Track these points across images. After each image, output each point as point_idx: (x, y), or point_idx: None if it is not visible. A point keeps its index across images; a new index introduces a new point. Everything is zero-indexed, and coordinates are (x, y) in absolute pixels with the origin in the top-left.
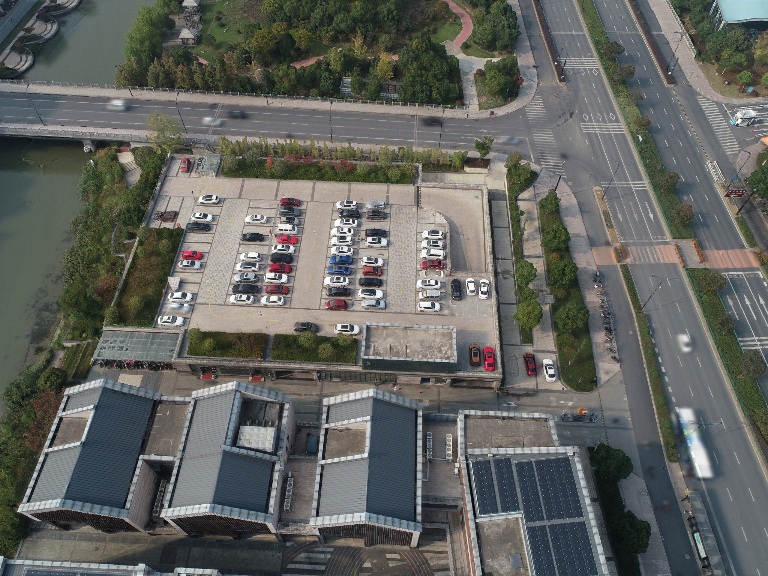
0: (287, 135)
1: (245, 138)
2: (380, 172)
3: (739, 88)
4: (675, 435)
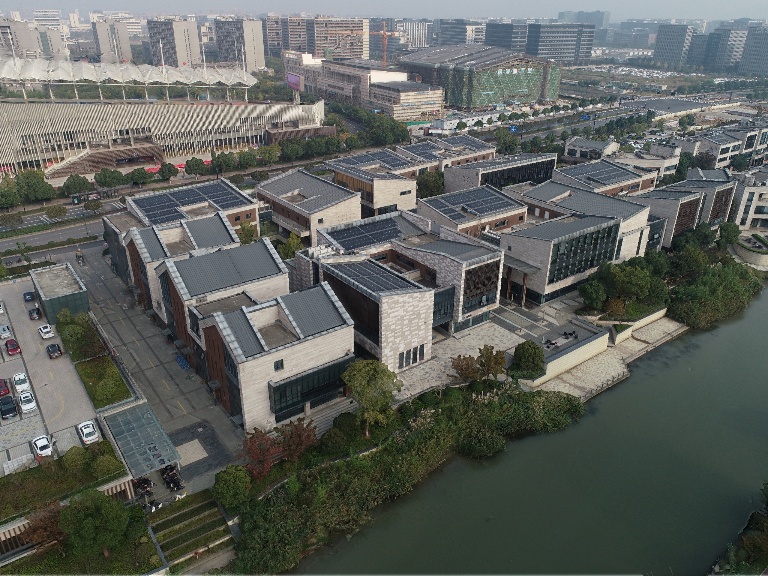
0: None
1: None
2: None
3: None
4: None
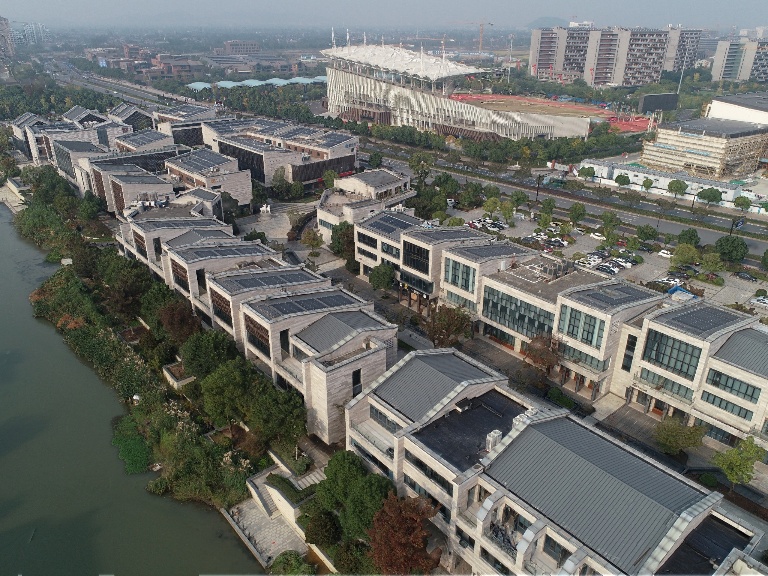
0: None
1: None
2: None
3: (214, 103)
4: None
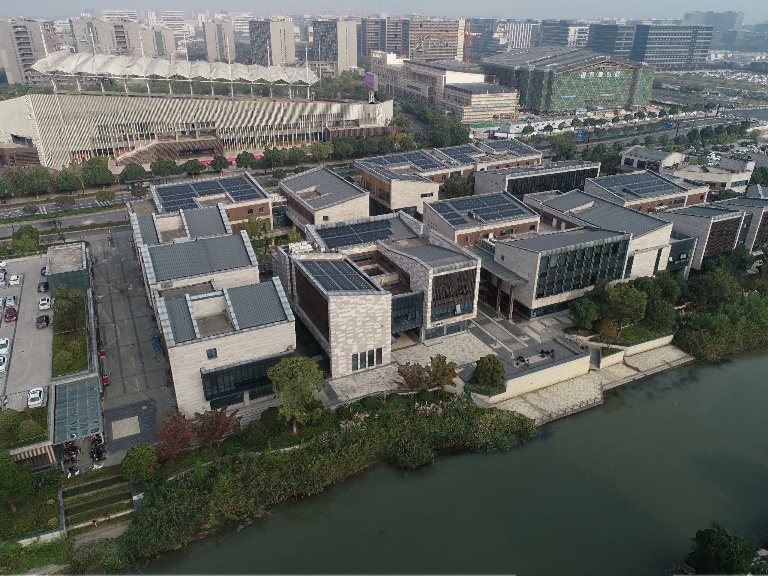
0: None
1: None
2: None
3: None
4: None
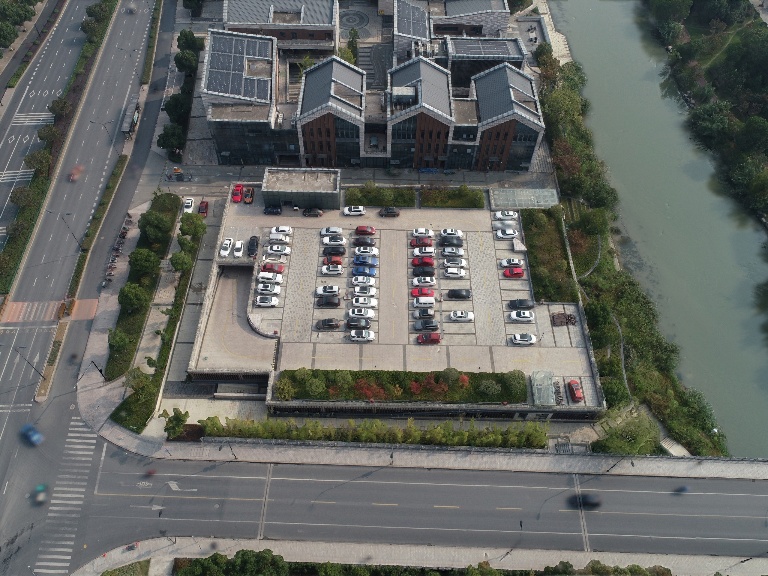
0: (461, 480)
1: (513, 436)
2: (322, 378)
3: None
4: None
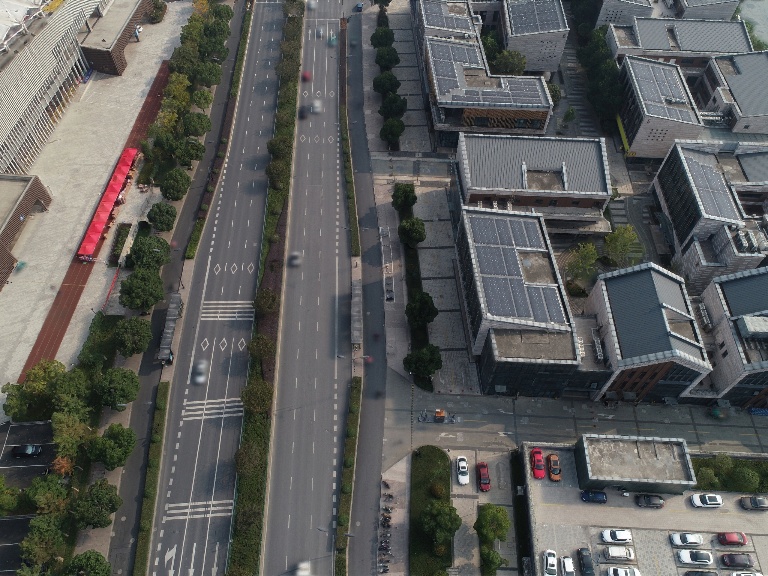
0: None
1: None
2: None
3: None
4: (346, 403)
